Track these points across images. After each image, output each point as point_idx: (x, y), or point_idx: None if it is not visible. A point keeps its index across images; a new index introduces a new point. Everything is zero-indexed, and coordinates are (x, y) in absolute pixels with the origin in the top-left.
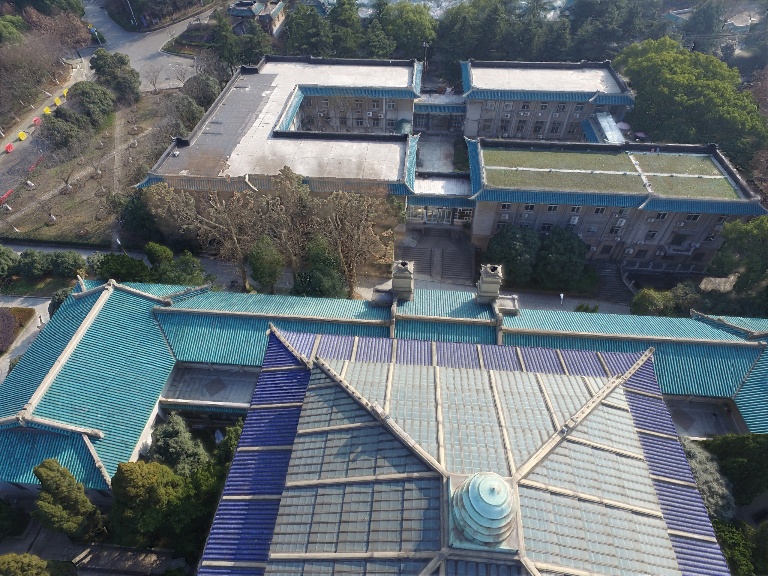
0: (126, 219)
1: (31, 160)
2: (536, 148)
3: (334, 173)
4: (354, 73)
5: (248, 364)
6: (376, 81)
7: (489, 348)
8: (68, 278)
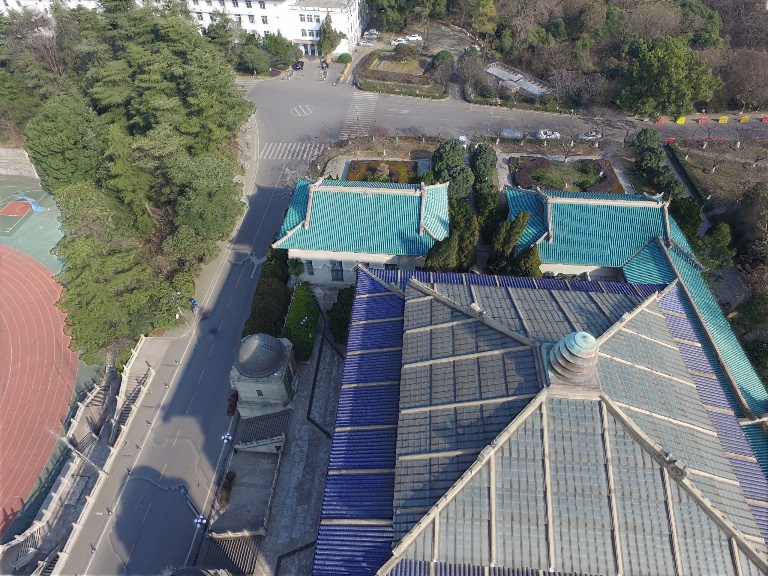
0: (743, 204)
1: (764, 134)
2: None
3: None
4: None
5: None
6: None
7: (758, 471)
8: None
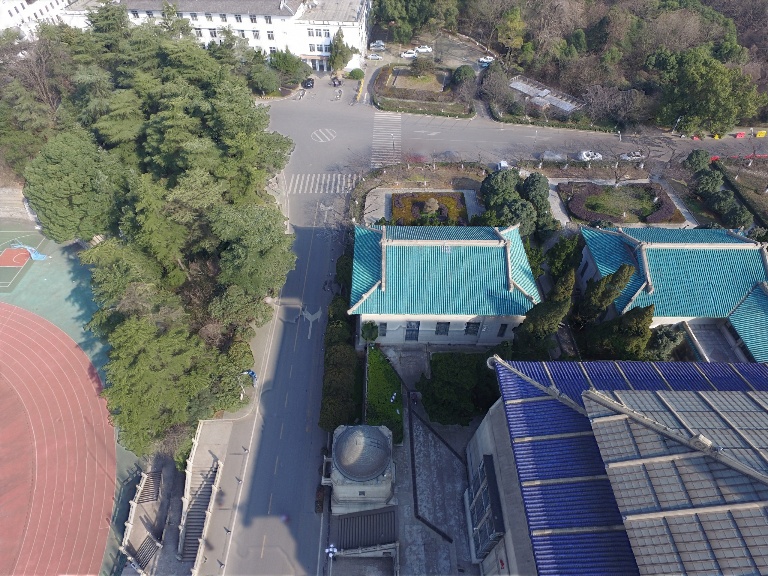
0: None
1: None
2: None
3: None
4: None
5: None
6: None
7: None
8: (723, 226)
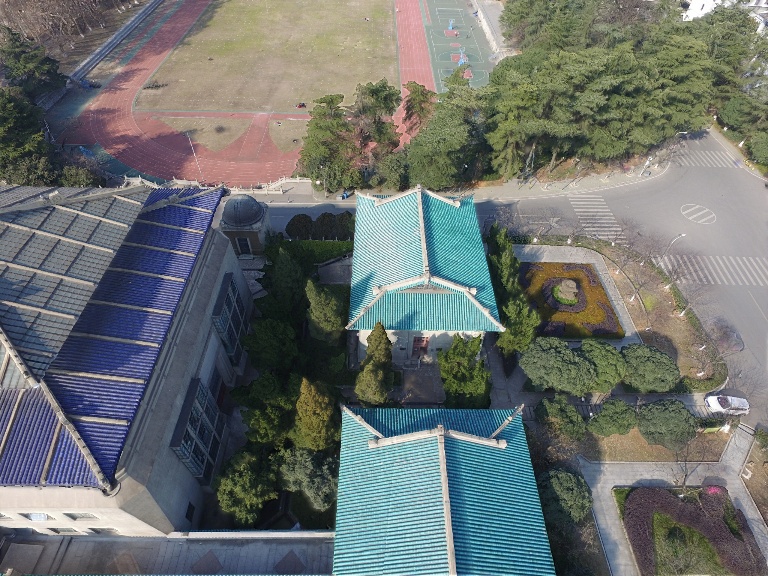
0: None
1: None
2: None
3: None
4: None
5: (226, 575)
6: None
7: None
8: None
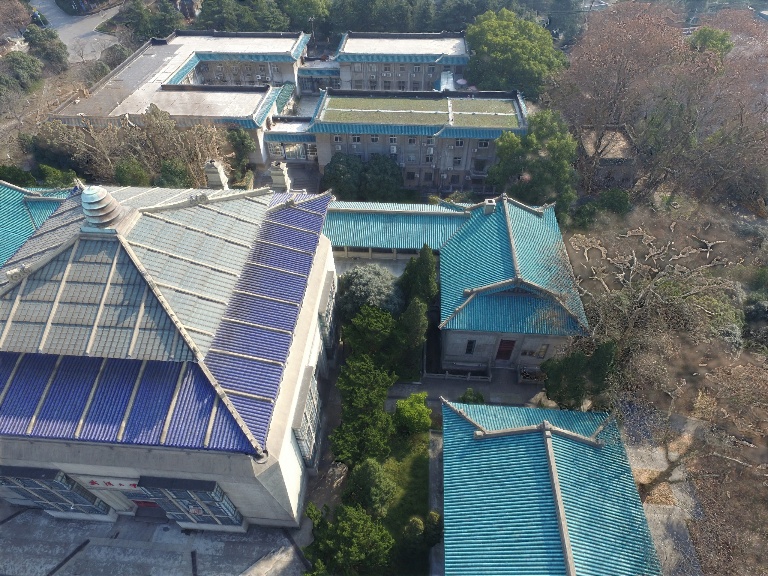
0: (30, 151)
1: None
2: (375, 96)
3: (201, 114)
4: (248, 43)
5: None
6: (264, 49)
7: None
8: None
